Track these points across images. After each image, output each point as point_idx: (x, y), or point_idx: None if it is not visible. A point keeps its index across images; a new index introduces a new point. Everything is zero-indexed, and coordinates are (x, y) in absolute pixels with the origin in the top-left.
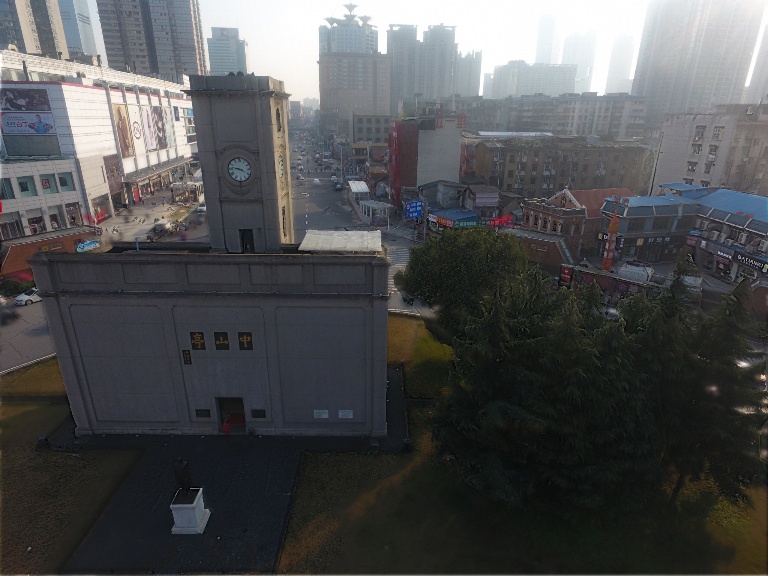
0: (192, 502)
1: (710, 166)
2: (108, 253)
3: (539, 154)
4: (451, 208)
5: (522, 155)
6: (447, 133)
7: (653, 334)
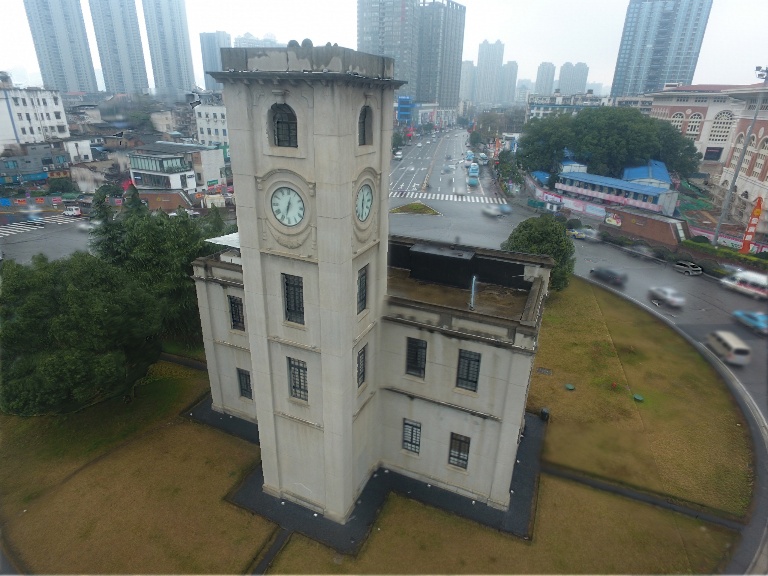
0: None
1: None
2: None
3: None
4: None
5: None
6: None
7: None
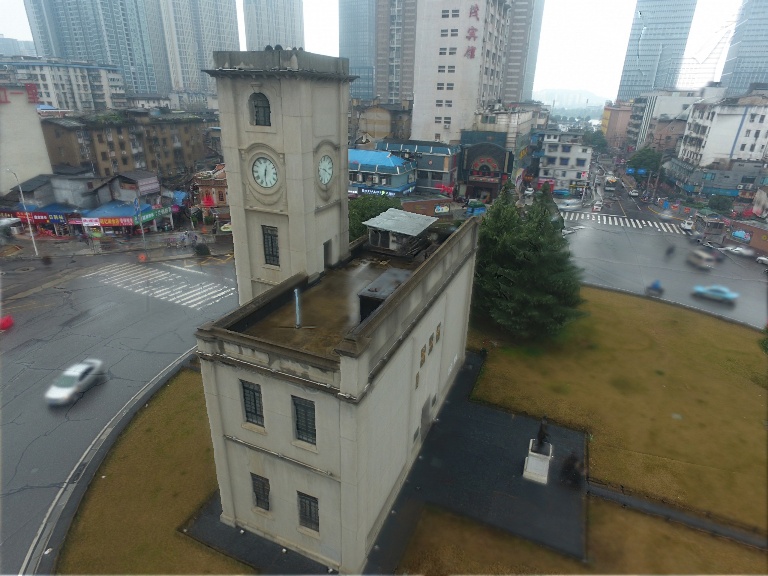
0: (549, 444)
1: None
2: (392, 296)
3: (121, 131)
4: (100, 205)
5: (106, 133)
6: (17, 110)
7: None
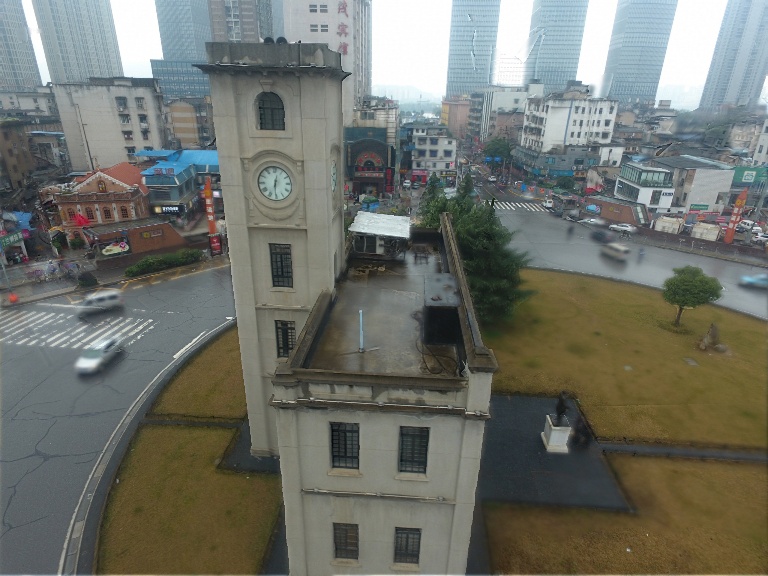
0: (564, 416)
1: (146, 133)
2: (468, 302)
3: None
4: None
5: None
6: None
7: (470, 209)
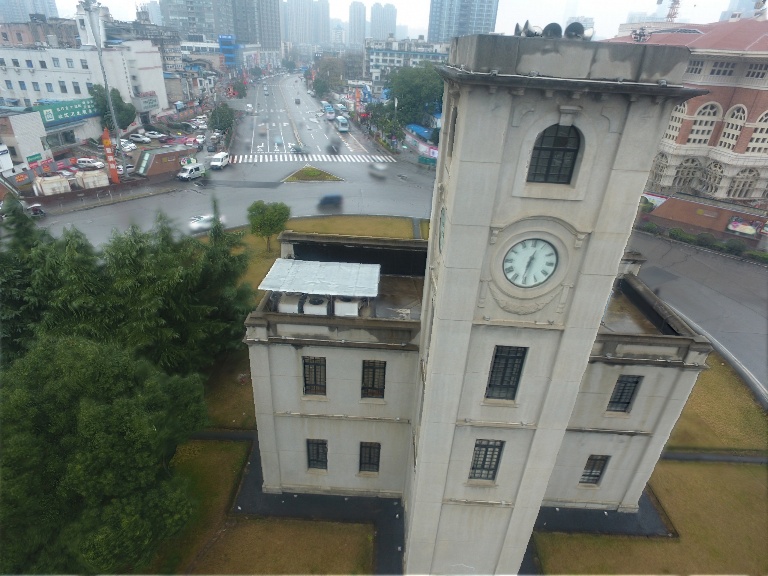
0: None
1: None
2: None
3: None
4: None
5: None
6: None
7: (87, 242)
